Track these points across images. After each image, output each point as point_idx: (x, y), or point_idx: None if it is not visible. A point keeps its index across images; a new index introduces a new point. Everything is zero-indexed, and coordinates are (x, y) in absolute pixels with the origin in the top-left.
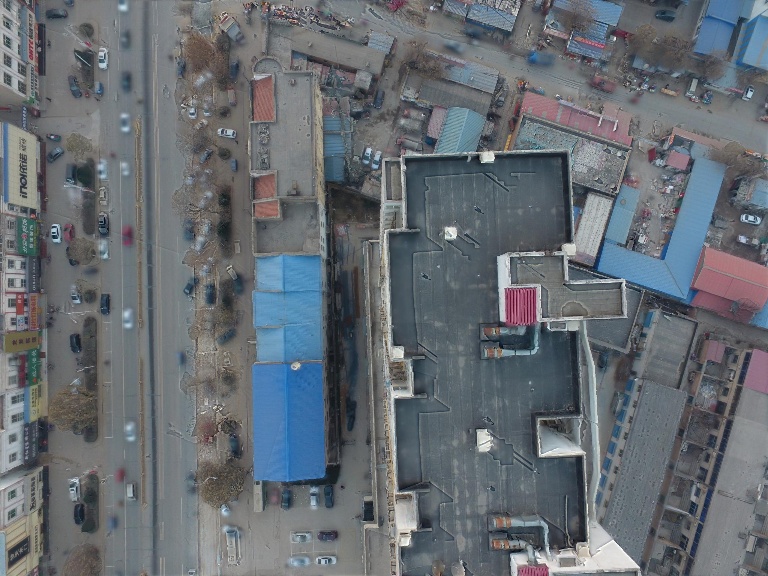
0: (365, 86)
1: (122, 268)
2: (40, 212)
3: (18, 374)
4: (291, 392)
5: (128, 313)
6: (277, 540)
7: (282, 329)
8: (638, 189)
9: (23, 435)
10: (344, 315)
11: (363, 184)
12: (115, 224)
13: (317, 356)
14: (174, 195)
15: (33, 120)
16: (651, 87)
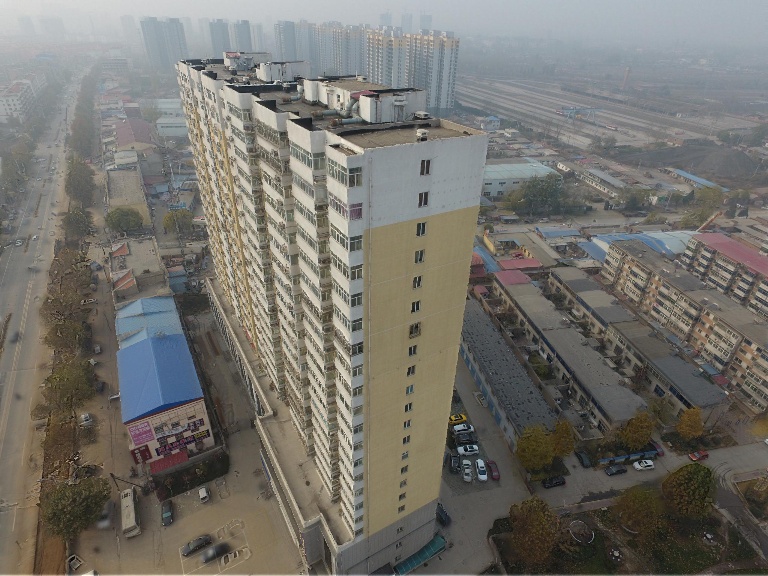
0: None
1: None
2: None
3: None
4: (157, 351)
5: None
6: (160, 568)
7: (144, 330)
8: None
9: None
10: (204, 357)
11: (201, 290)
12: None
13: None
14: None
15: None
16: None
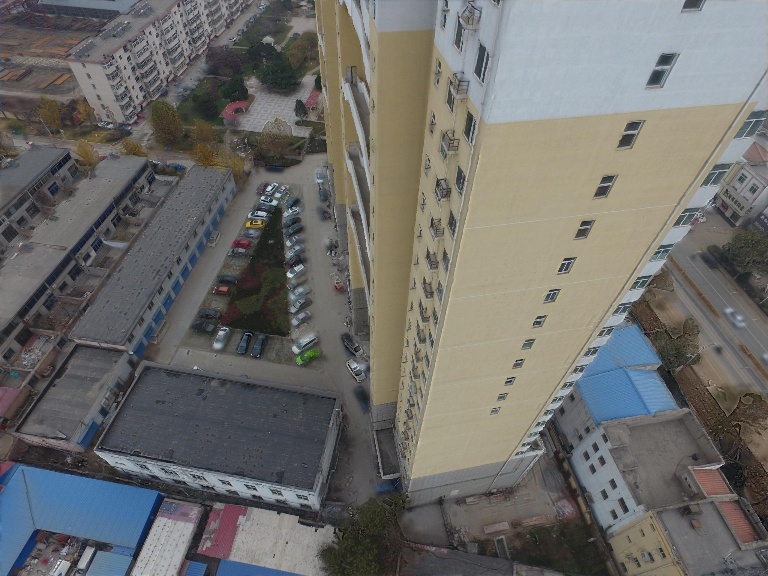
0: None
1: None
2: None
3: None
4: None
5: (767, 359)
6: None
7: None
8: None
9: None
10: None
11: None
12: None
13: None
14: None
15: None
16: None
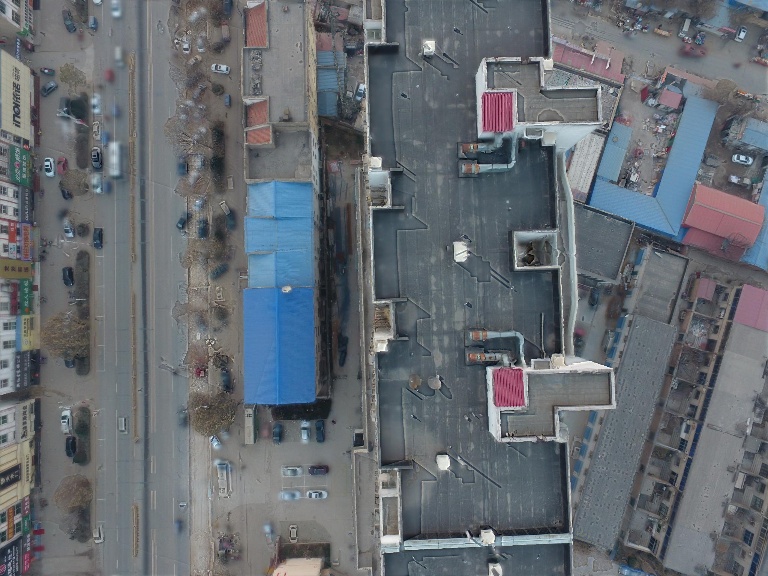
0: (359, 21)
1: (115, 203)
2: (33, 146)
3: (10, 301)
4: (282, 316)
5: (121, 247)
6: (268, 474)
7: (273, 255)
8: (630, 127)
9: (15, 362)
10: (336, 251)
11: (356, 119)
12: (108, 159)
13: (308, 283)
14: (167, 123)
15: (27, 54)
16: (644, 27)
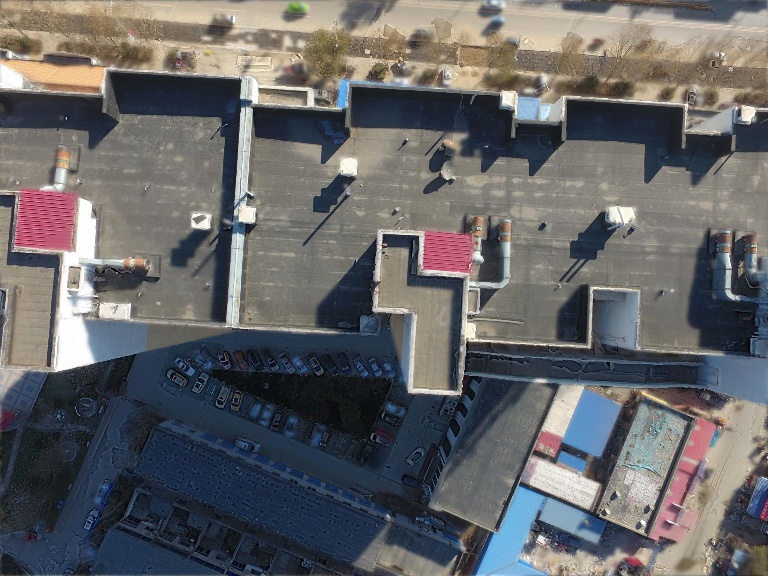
0: None
1: None
2: None
3: None
4: None
5: None
6: None
7: None
8: None
9: None
10: None
11: None
12: None
13: None
14: None
15: None
16: (709, 569)
